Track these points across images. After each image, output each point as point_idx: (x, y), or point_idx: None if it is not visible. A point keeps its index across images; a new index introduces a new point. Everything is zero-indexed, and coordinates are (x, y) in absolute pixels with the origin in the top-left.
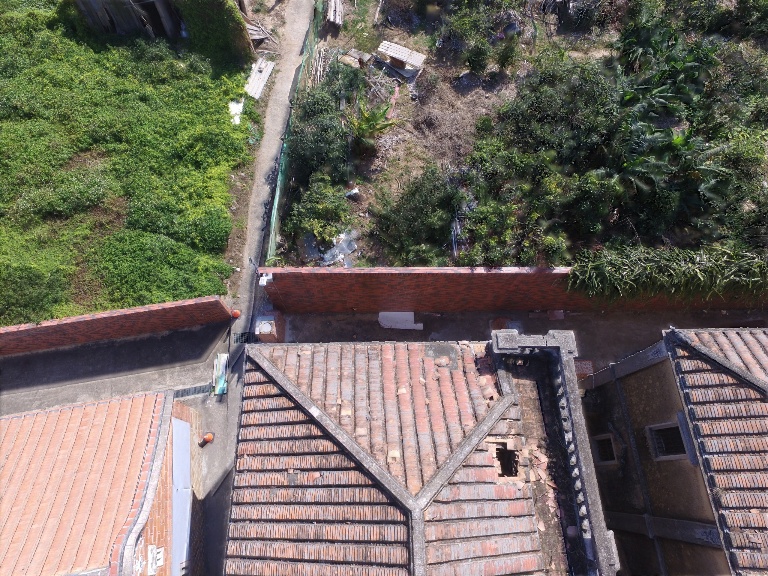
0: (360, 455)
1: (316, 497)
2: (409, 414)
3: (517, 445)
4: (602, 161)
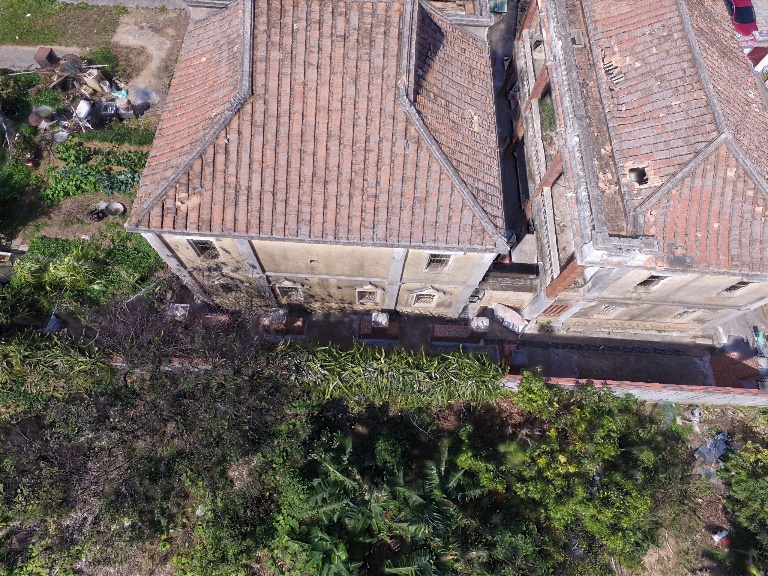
0: (757, 172)
1: (764, 165)
2: (715, 204)
3: (631, 185)
4: (466, 511)
